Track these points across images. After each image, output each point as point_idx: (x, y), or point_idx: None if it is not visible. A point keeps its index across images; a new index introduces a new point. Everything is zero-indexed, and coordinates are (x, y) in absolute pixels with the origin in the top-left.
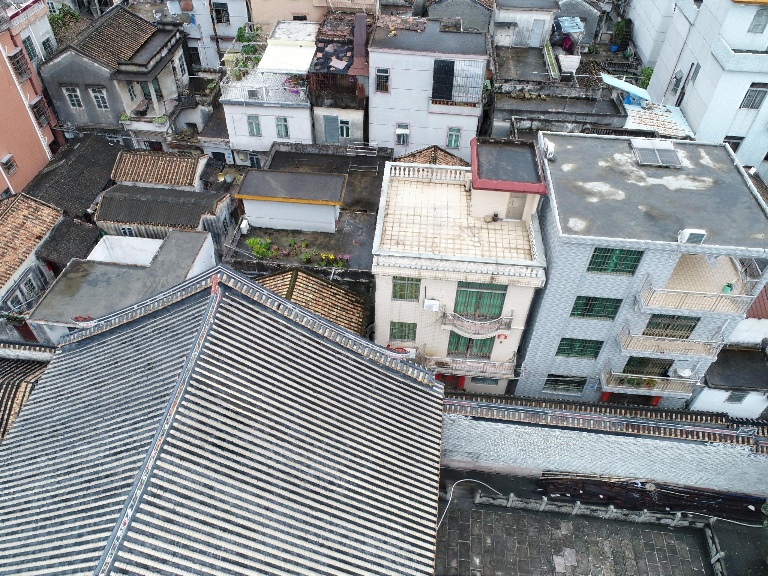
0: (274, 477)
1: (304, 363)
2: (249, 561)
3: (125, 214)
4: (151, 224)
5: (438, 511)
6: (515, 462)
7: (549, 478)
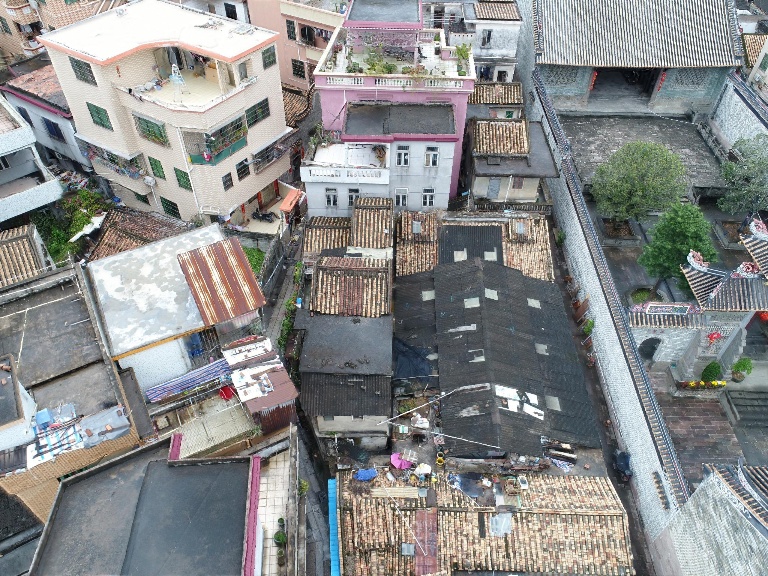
0: (661, 6)
1: (711, 6)
2: (632, 5)
3: (763, 5)
4: (765, 13)
5: (685, 121)
6: (729, 137)
7: (730, 151)
